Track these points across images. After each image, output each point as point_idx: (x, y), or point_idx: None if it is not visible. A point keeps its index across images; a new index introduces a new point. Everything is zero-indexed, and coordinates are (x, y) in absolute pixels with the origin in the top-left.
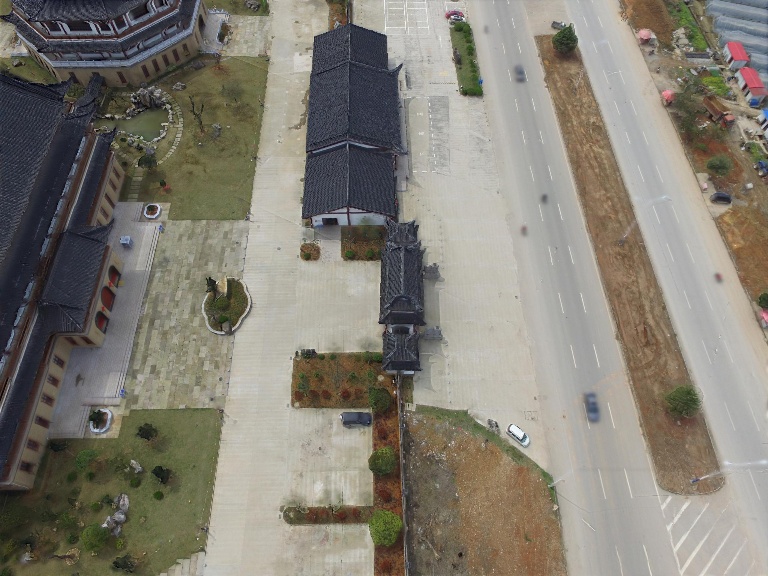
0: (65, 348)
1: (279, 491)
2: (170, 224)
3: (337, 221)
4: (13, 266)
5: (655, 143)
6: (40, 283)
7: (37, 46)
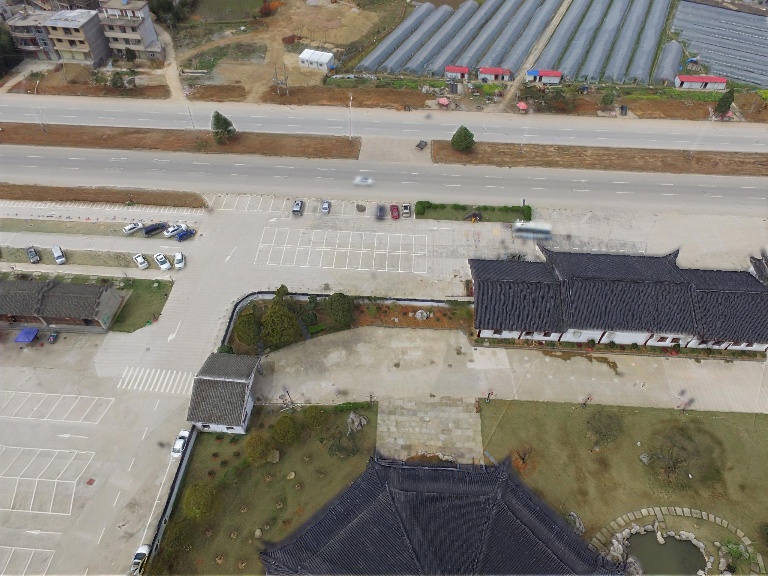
0: None
1: None
2: None
3: None
4: None
5: (570, 126)
6: None
7: None
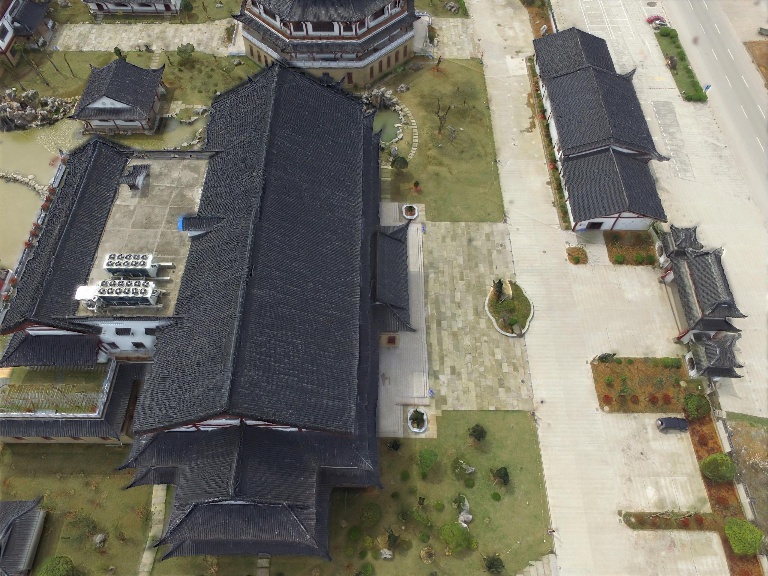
0: None
1: (612, 495)
2: (430, 225)
3: (601, 225)
4: None
5: None
6: None
7: (268, 46)
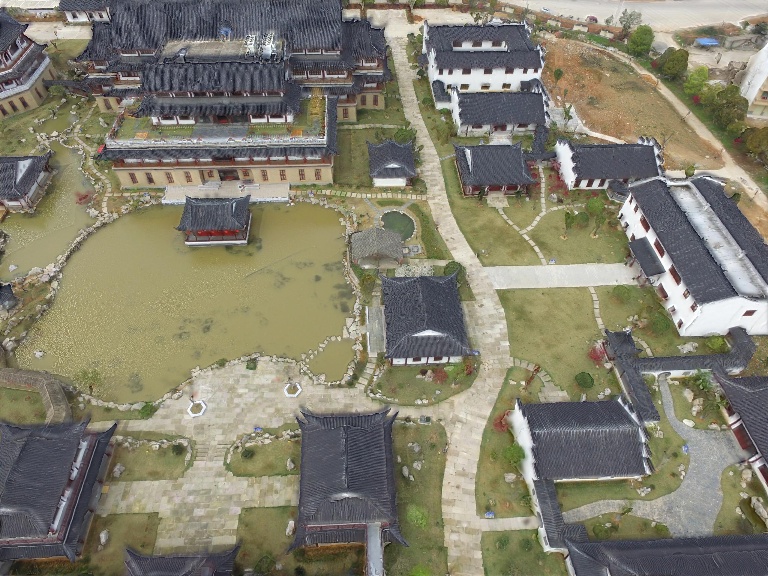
0: None
1: None
2: None
3: None
4: None
5: None
6: None
7: None
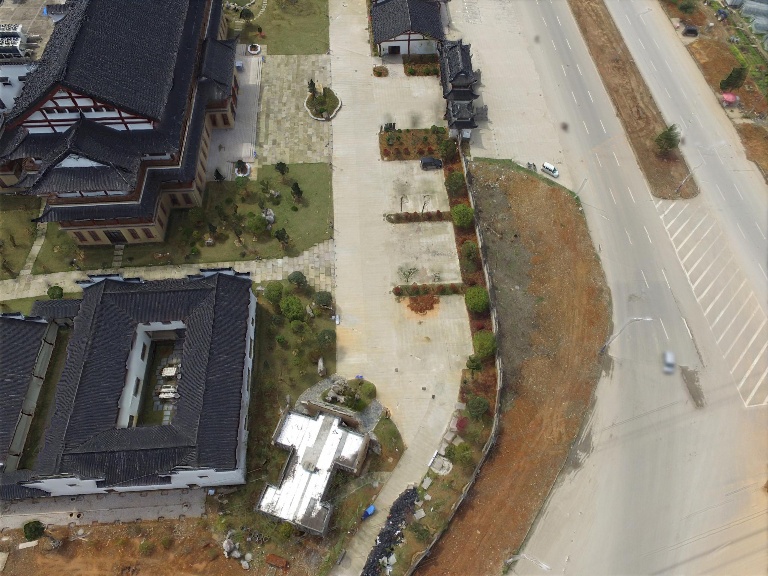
0: (209, 125)
1: (381, 206)
2: (269, 57)
3: (399, 50)
4: (182, 48)
5: (638, 1)
6: (196, 67)
7: None
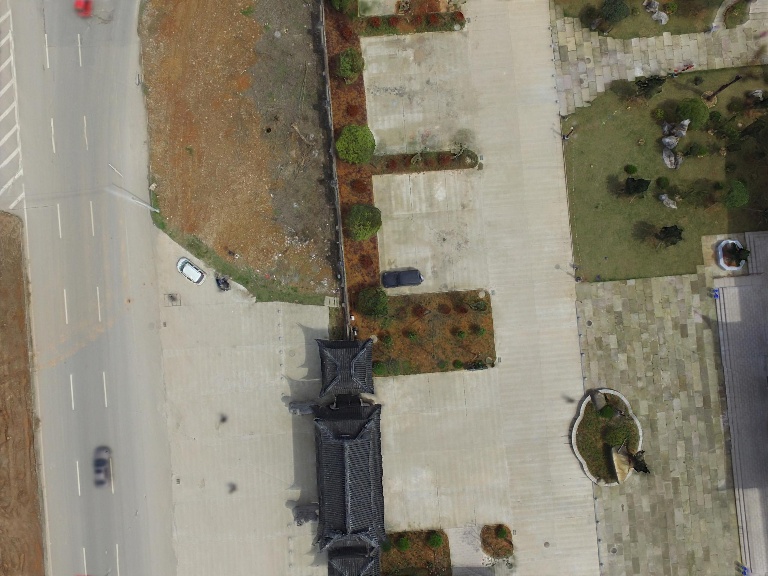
0: None
1: (487, 186)
2: None
3: None
4: None
5: None
6: None
7: None
